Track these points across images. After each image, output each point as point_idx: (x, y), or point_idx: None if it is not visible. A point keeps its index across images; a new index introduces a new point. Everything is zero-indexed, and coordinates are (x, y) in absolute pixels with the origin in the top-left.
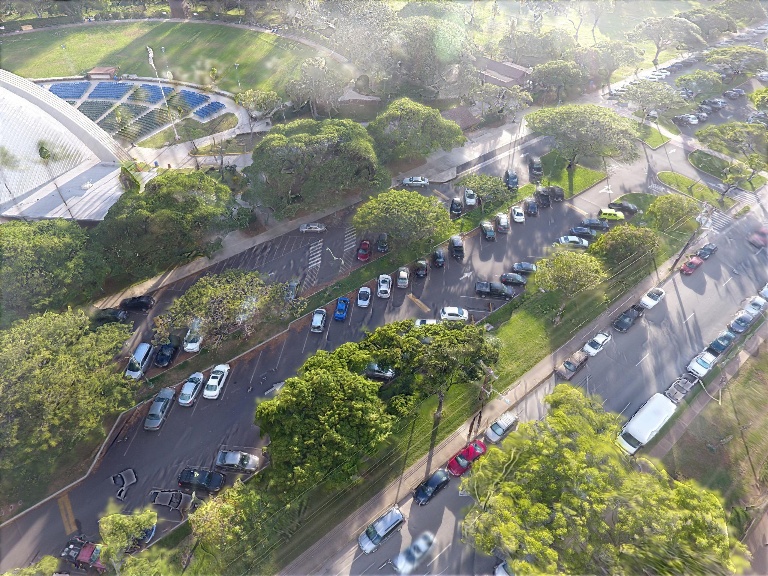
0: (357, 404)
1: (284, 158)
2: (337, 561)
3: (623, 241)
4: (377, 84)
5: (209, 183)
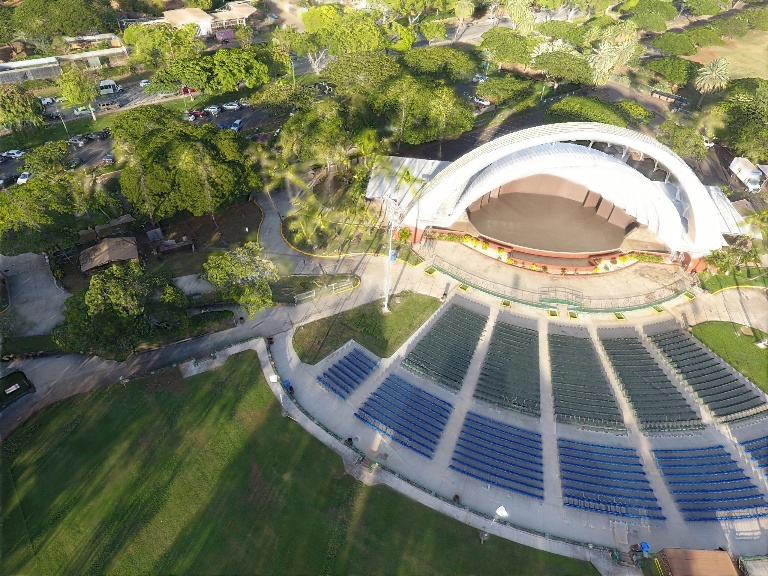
0: None
1: None
2: None
3: (20, 90)
4: None
5: None
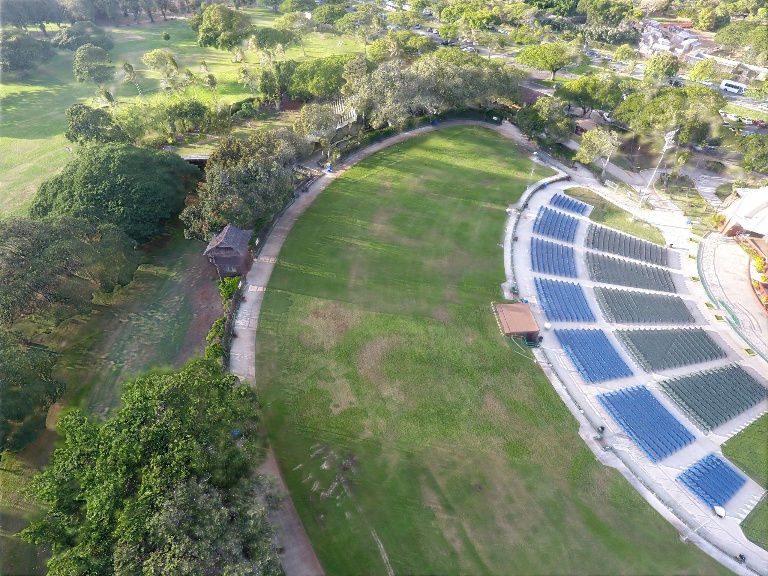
0: None
1: None
2: None
3: None
4: None
5: None
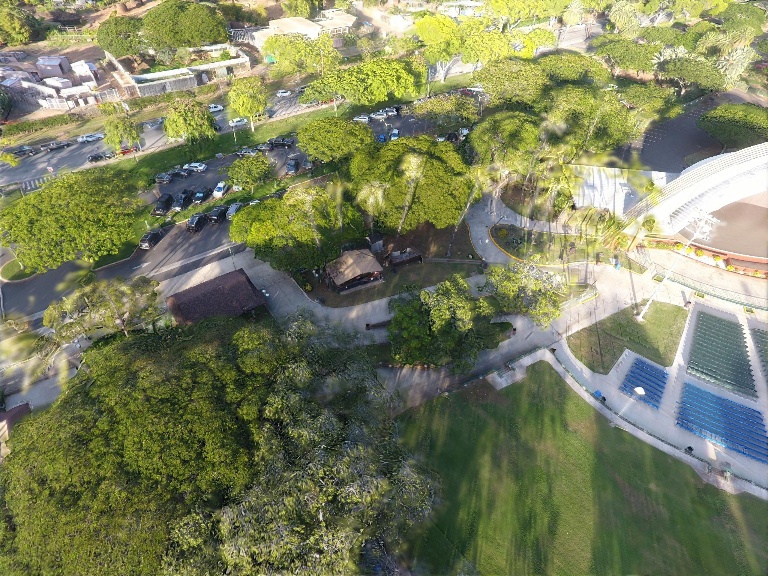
0: None
1: None
2: None
3: None
4: None
5: None
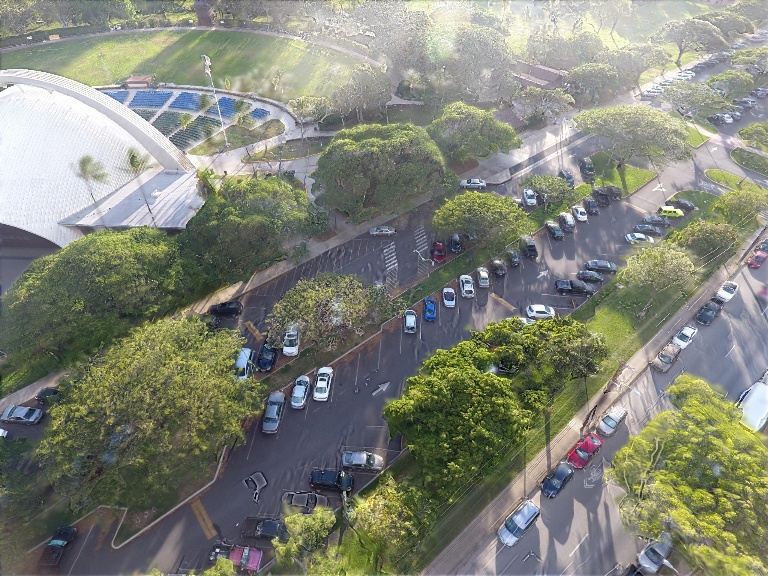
0: (498, 400)
1: (359, 163)
2: (481, 555)
3: (704, 237)
4: (417, 89)
5: (286, 189)
